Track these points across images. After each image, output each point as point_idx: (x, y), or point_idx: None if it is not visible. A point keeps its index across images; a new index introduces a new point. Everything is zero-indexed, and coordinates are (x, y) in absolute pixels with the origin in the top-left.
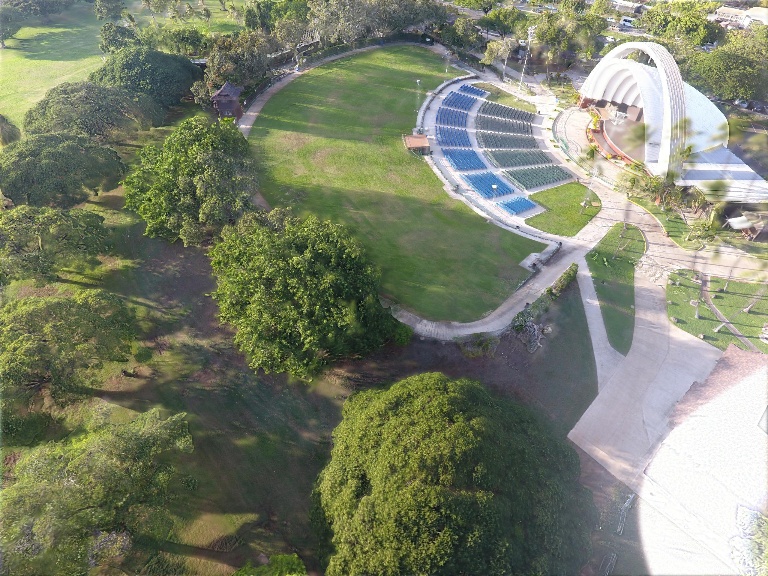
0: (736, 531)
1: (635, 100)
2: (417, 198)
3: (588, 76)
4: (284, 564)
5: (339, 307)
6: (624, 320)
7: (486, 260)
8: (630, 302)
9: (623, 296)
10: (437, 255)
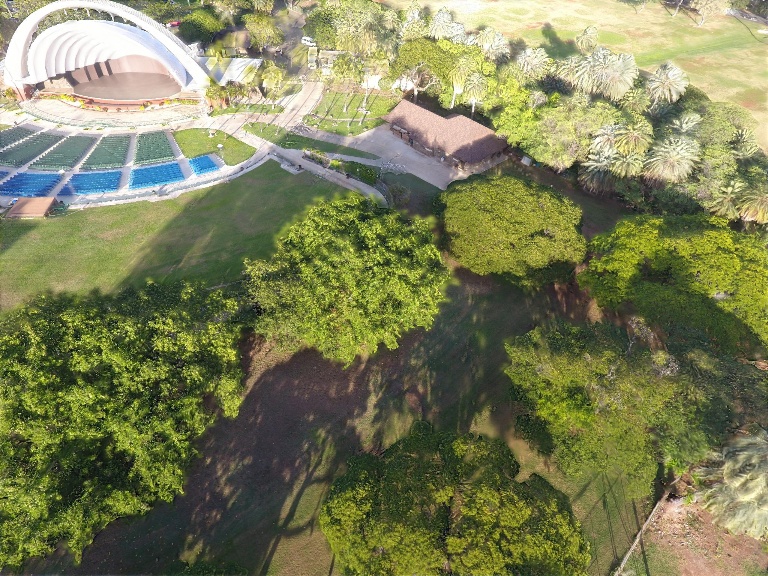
0: (495, 147)
1: (75, 62)
2: (168, 219)
3: (4, 66)
4: (587, 276)
5: (411, 222)
6: (351, 150)
7: (288, 188)
8: (333, 145)
9: (328, 145)
10: (278, 212)
